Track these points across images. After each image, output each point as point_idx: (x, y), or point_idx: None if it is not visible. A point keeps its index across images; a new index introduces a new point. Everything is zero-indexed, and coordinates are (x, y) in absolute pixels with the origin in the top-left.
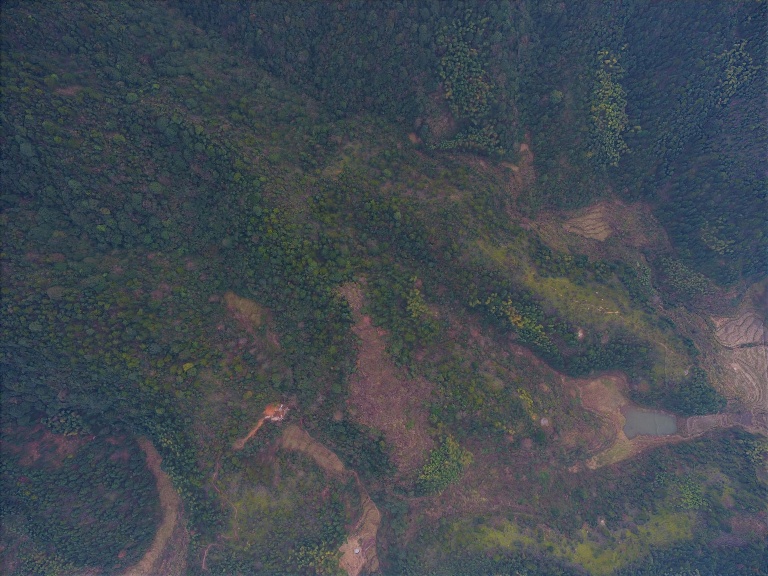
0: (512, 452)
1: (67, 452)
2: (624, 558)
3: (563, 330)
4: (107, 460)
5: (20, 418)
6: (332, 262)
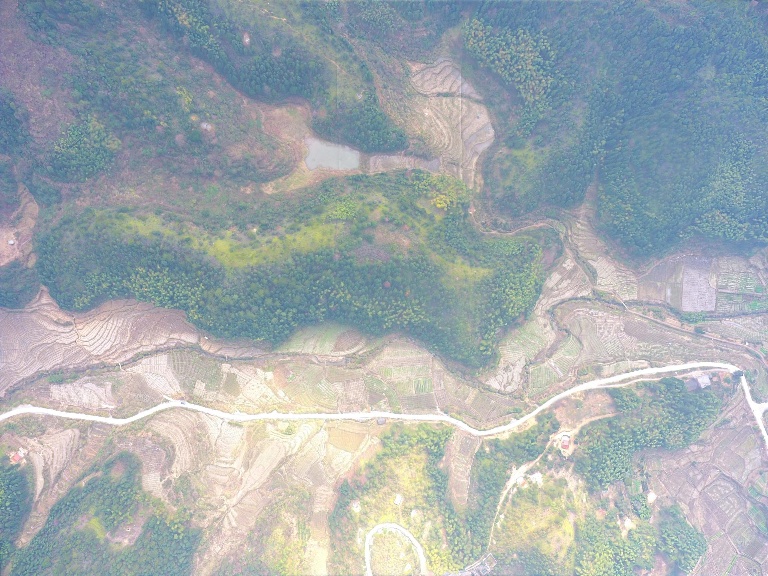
0: (173, 155)
1: None
2: (262, 257)
3: (226, 29)
4: None
5: None
6: None
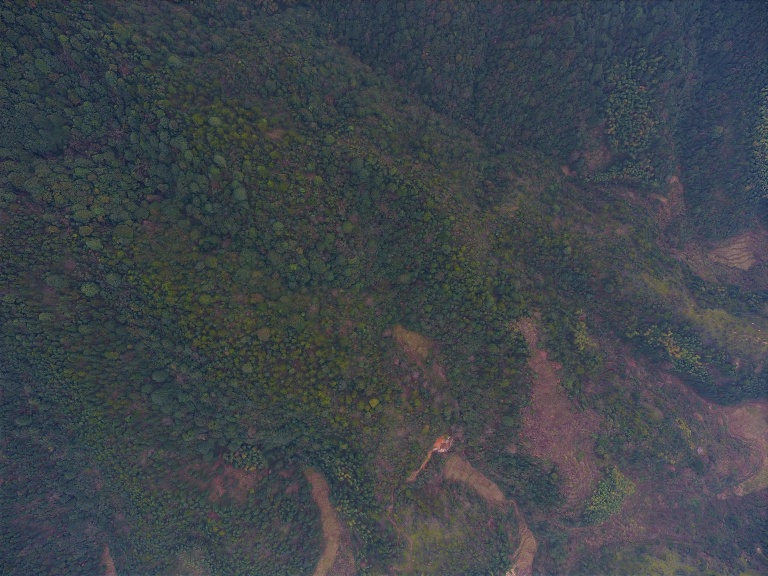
0: (667, 481)
1: (247, 487)
2: None
3: (721, 361)
4: (284, 494)
5: (206, 454)
6: (507, 297)
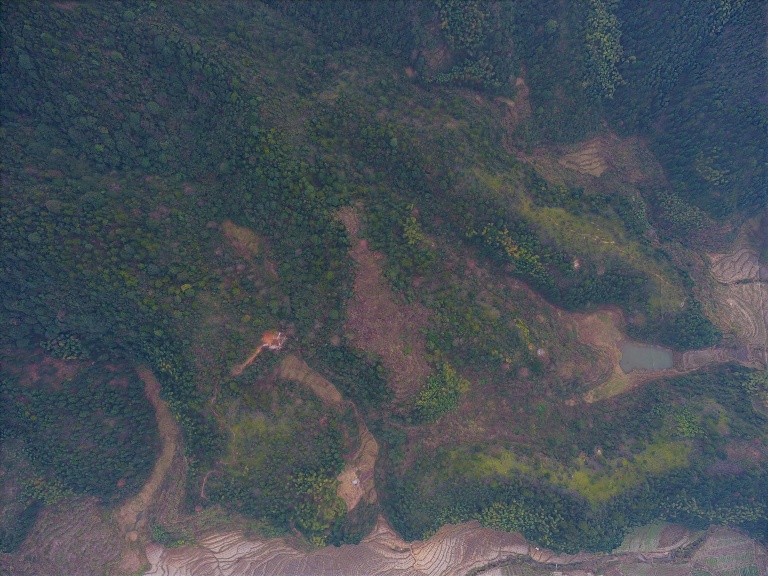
0: (509, 383)
1: (66, 376)
2: (621, 485)
3: (559, 259)
4: (106, 385)
5: (19, 340)
6: (329, 187)
